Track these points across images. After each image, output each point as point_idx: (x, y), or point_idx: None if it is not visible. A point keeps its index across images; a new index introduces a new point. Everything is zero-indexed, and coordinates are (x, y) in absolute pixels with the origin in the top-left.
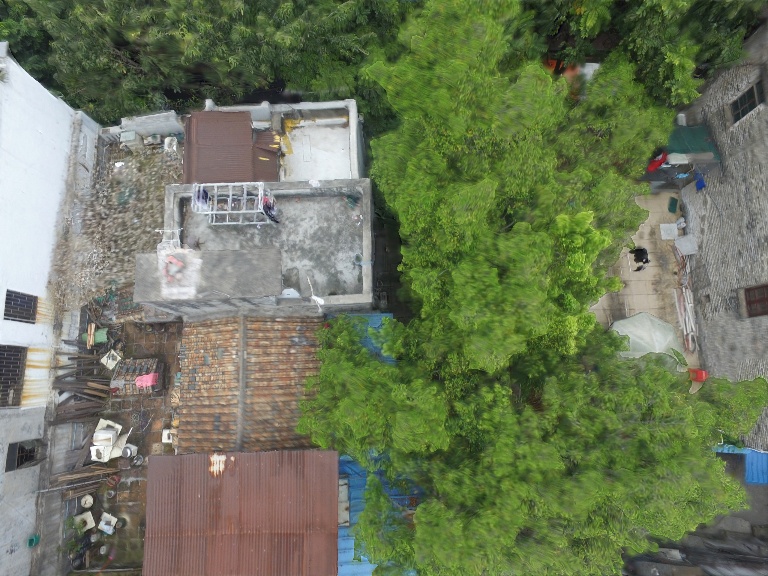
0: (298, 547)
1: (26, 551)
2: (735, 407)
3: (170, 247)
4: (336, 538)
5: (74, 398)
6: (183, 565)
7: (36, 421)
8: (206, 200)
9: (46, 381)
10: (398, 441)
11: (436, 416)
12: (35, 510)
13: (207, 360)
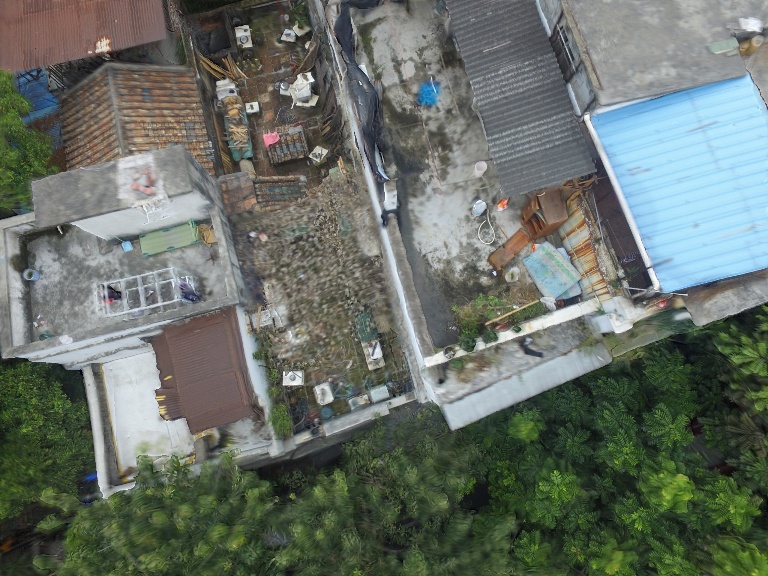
0: (28, 5)
1: None
2: None
3: (154, 204)
4: None
5: None
6: None
7: None
8: (196, 299)
9: None
10: None
11: None
12: None
13: None
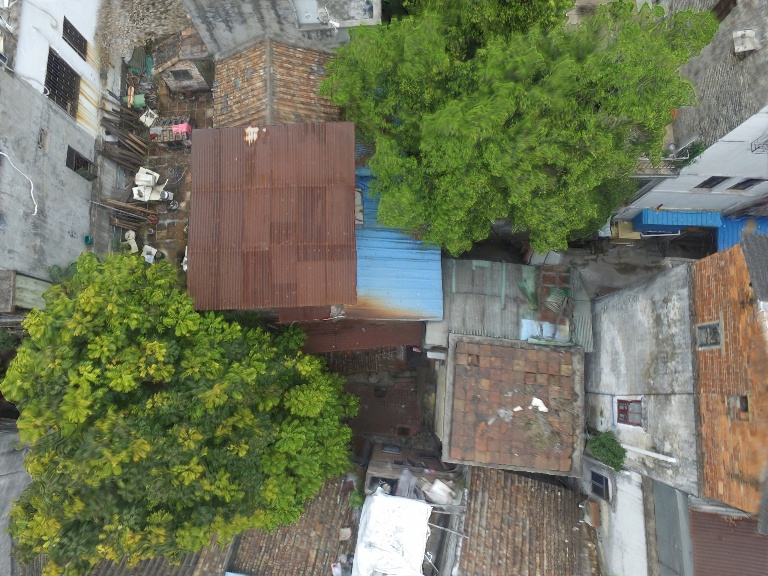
0: (321, 197)
1: (83, 246)
2: (686, 27)
3: None
4: (353, 190)
5: (118, 145)
6: (224, 212)
7: (88, 145)
8: None
9: (95, 118)
10: (406, 66)
11: (438, 41)
12: (89, 218)
13: (238, 84)
